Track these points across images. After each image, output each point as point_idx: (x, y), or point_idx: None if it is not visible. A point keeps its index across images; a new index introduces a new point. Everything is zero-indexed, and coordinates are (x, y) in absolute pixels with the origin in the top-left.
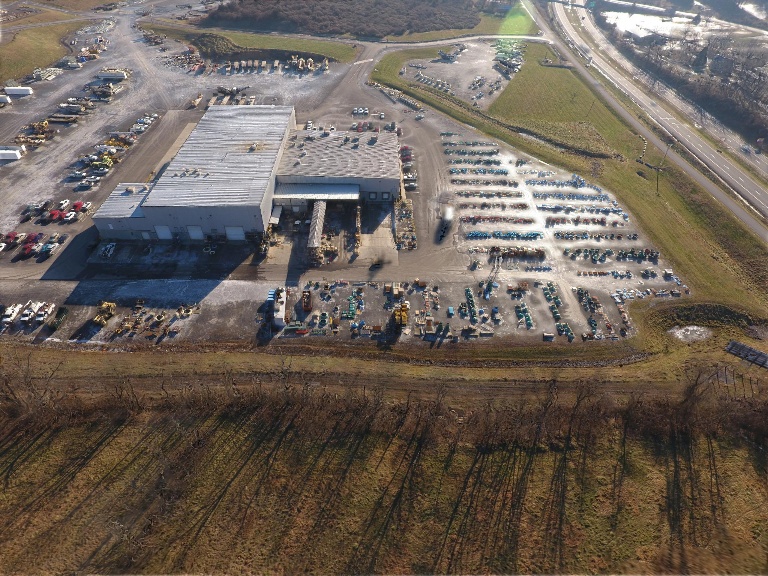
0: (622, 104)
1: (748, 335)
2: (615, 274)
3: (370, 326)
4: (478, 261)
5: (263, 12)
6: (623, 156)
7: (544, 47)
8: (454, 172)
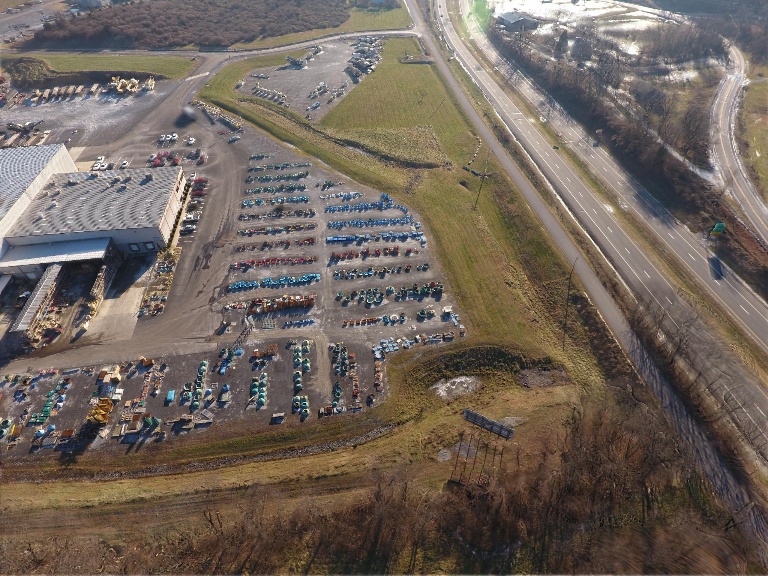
0: (472, 101)
1: (518, 382)
2: (385, 320)
3: (59, 432)
4: (228, 322)
5: (95, 28)
6: (452, 163)
7: (410, 42)
8: (246, 205)
